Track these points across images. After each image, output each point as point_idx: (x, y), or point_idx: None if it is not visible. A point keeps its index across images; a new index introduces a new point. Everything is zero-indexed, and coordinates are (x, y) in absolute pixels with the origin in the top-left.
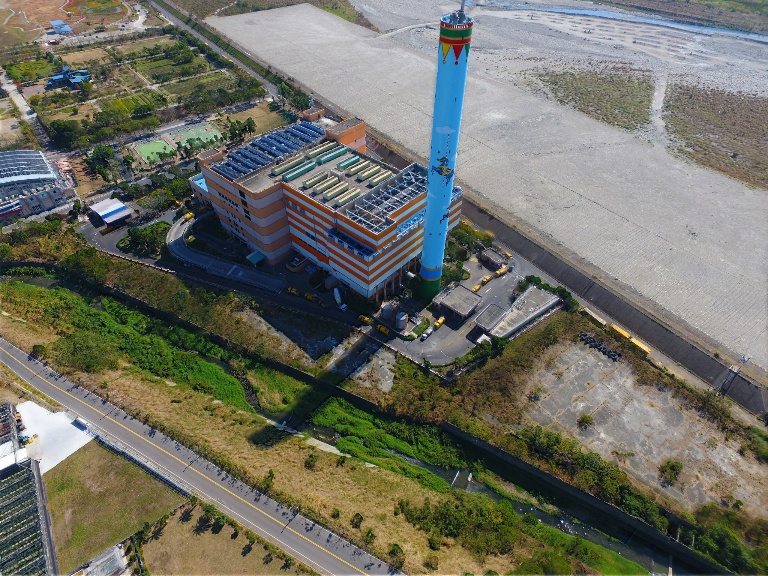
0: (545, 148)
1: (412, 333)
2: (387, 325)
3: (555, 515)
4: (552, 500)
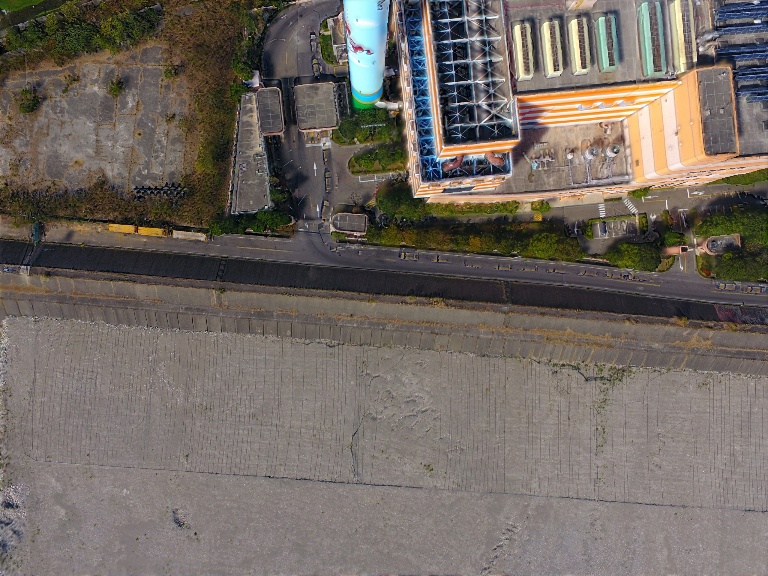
0: None
1: (329, 32)
2: None
3: None
4: None
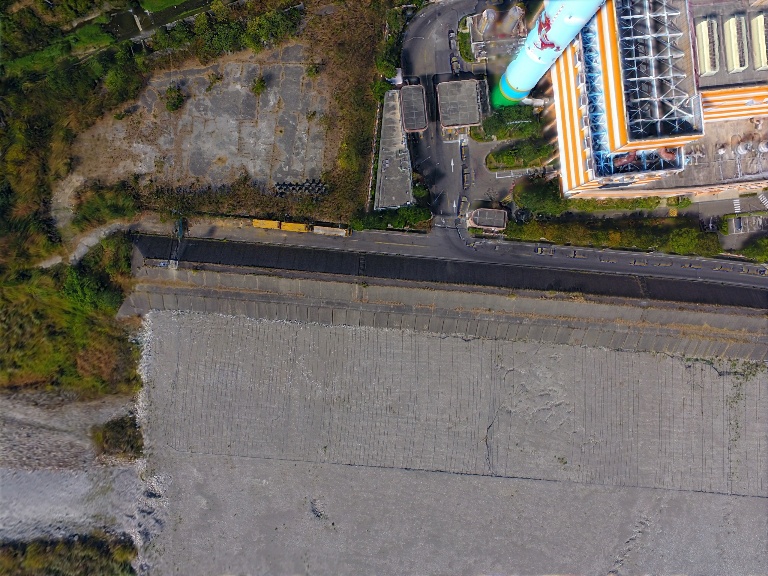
0: (633, 575)
1: (467, 30)
2: (497, 12)
3: None
4: None
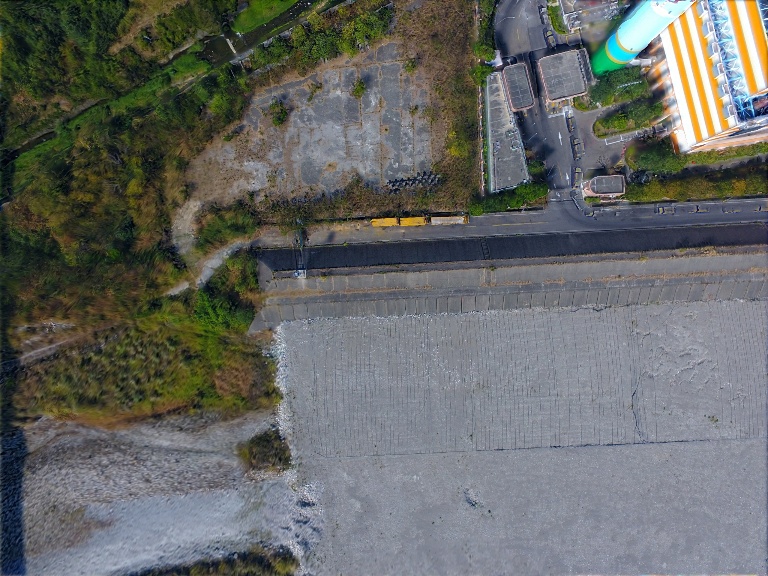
0: None
1: (557, 3)
2: None
3: (316, 1)
4: (326, 6)
